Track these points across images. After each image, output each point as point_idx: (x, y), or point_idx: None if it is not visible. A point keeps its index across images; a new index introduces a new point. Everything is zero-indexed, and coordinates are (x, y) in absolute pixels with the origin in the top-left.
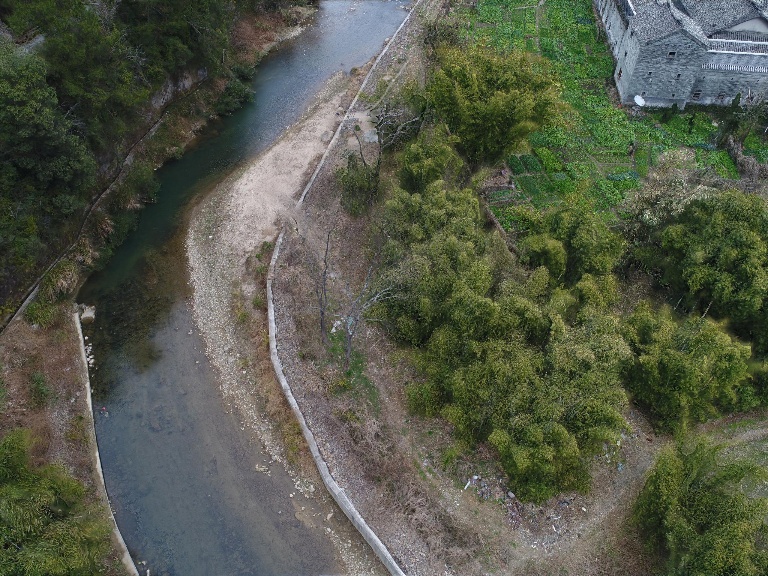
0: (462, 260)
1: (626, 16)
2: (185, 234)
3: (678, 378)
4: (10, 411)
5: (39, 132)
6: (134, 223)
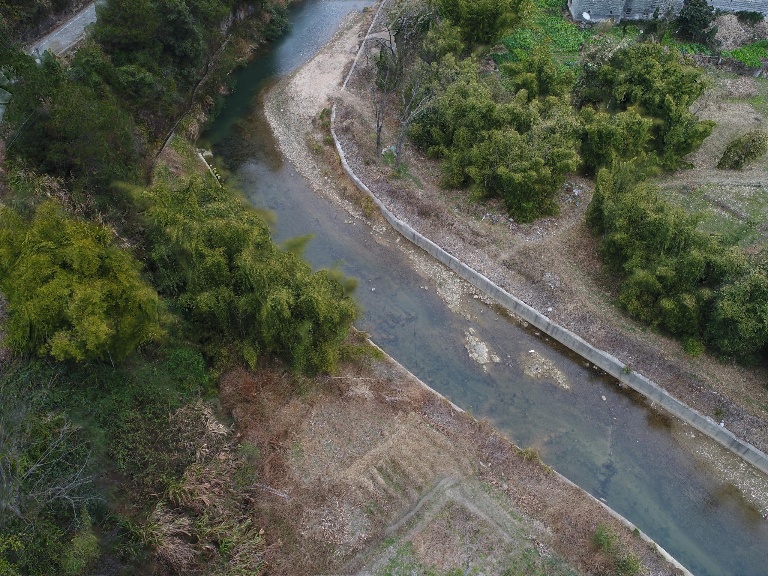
0: (470, 93)
1: None
2: (262, 110)
3: (609, 139)
4: (185, 187)
5: (180, 17)
6: (224, 104)
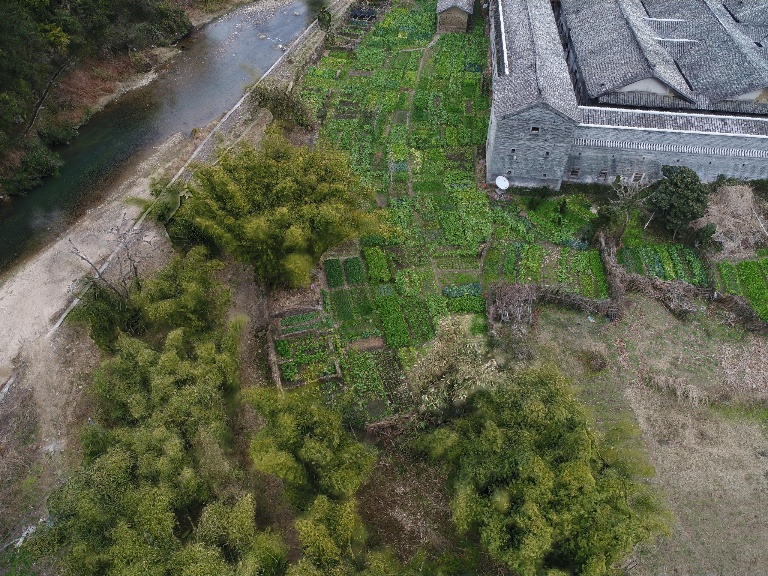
0: (162, 469)
1: (501, 72)
2: None
3: None
4: None
5: None
6: None
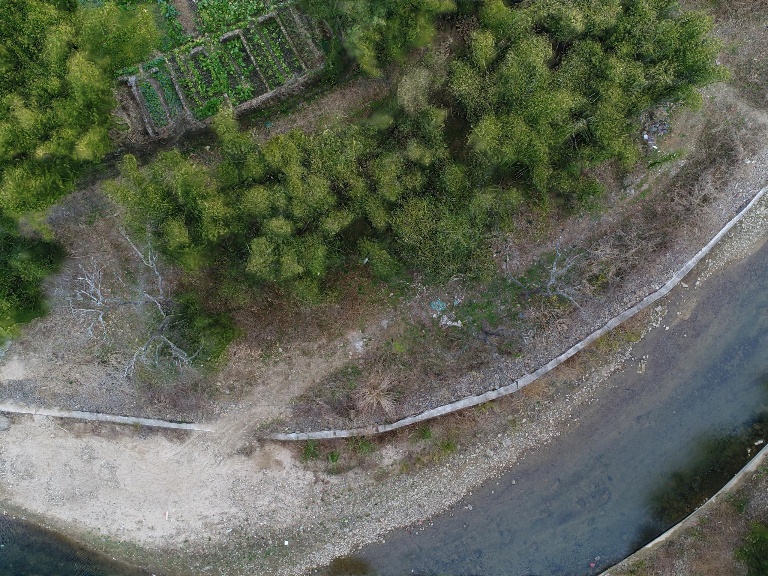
0: None
1: None
2: None
3: None
4: None
5: None
6: None
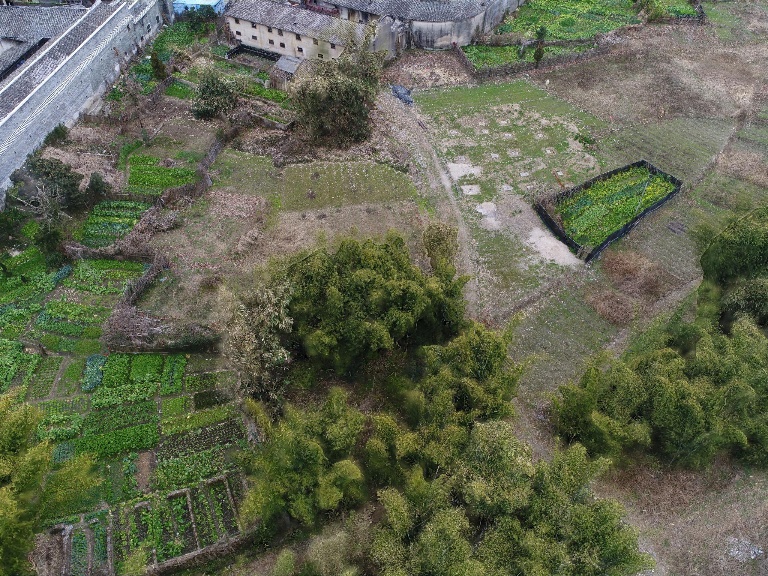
0: None
1: None
2: None
3: None
4: None
5: None
6: None
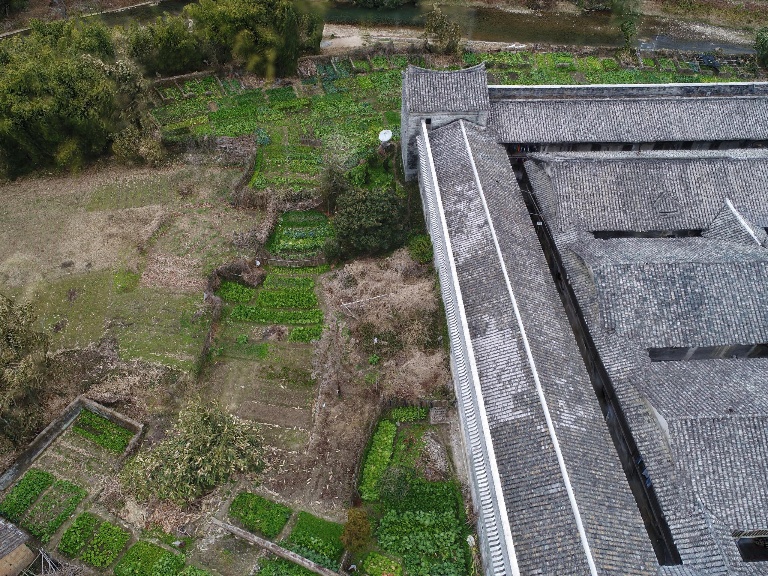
0: None
1: None
2: None
3: None
4: None
5: None
6: None
